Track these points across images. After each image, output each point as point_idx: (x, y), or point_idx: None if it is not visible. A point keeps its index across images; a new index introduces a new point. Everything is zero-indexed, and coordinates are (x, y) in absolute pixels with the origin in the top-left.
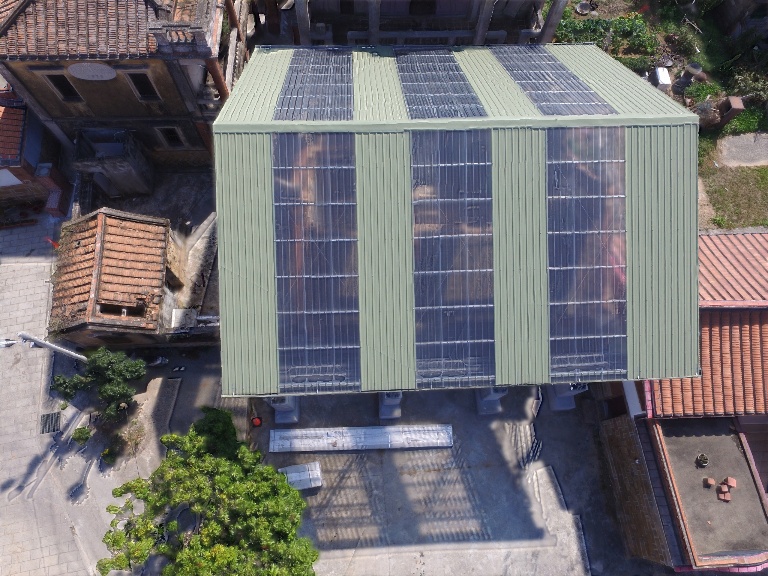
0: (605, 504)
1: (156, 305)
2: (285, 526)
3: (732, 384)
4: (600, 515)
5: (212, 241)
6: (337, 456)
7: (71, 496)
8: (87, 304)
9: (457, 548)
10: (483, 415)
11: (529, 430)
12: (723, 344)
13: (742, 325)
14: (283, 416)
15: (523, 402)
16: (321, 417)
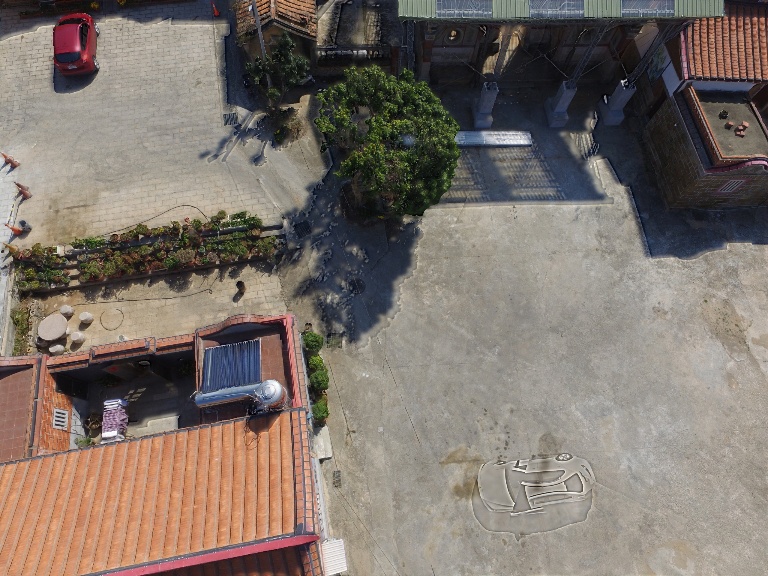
0: (649, 180)
1: (314, 24)
2: (441, 109)
3: (745, 60)
4: (645, 187)
5: (334, 15)
6: None
7: (254, 161)
8: (270, 11)
9: (540, 204)
10: (553, 128)
11: (589, 137)
12: (739, 30)
13: (752, 17)
14: None
15: (583, 121)
16: None
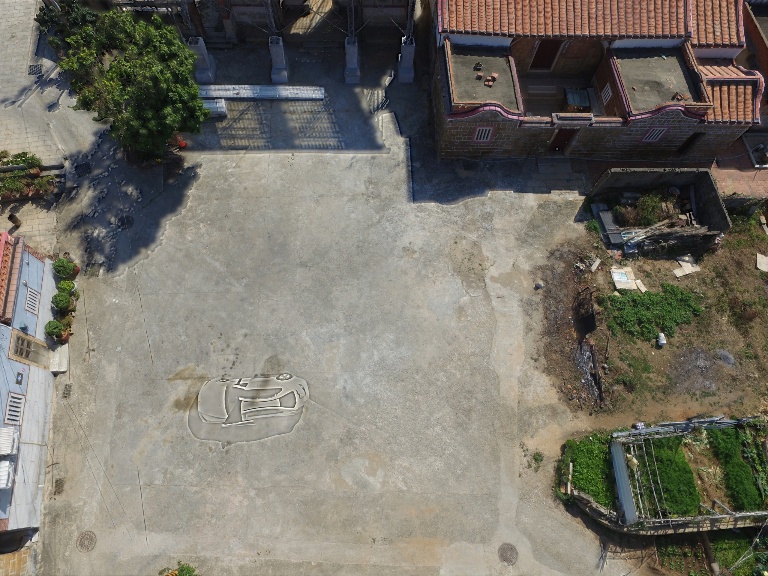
0: (428, 133)
1: None
2: (179, 51)
3: (500, 15)
4: (424, 139)
5: None
6: (239, 102)
7: (48, 108)
8: None
9: (318, 152)
10: (349, 84)
11: (381, 93)
12: None
13: None
14: (201, 72)
15: (379, 78)
16: (230, 82)
